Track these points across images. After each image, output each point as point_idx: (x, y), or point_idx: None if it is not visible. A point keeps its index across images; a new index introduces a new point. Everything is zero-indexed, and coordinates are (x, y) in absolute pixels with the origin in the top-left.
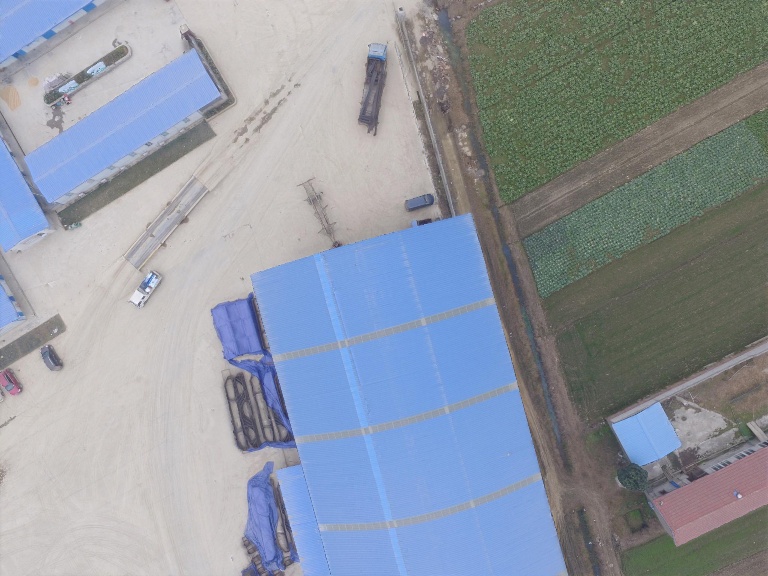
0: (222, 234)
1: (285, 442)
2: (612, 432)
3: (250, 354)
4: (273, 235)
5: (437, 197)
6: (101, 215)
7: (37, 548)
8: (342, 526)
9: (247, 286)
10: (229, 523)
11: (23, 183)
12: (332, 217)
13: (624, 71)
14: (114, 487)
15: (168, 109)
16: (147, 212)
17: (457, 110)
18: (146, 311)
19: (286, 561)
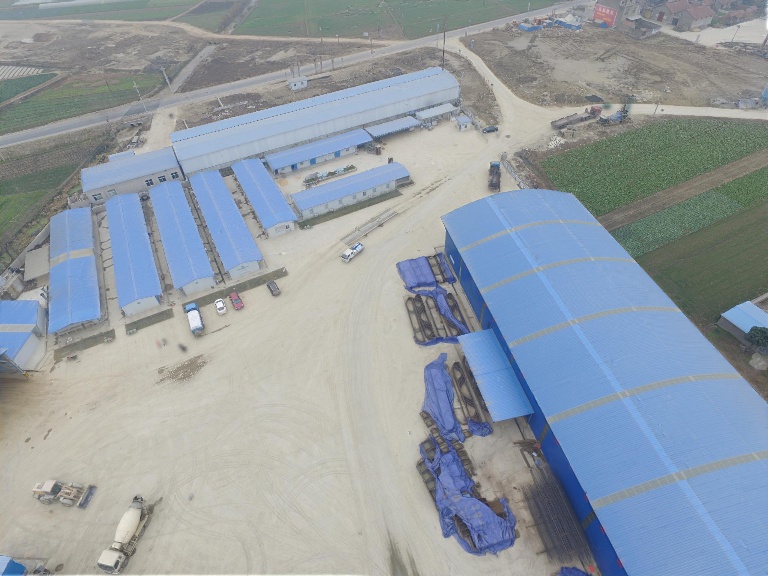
0: (405, 231)
1: None
2: (726, 331)
3: (425, 287)
4: (439, 232)
5: None
6: (326, 224)
7: (213, 425)
8: (530, 336)
9: (422, 254)
10: (407, 401)
11: (287, 203)
12: None
13: None
14: (302, 373)
15: (381, 178)
16: (356, 223)
17: (543, 188)
18: (349, 266)
19: (465, 433)
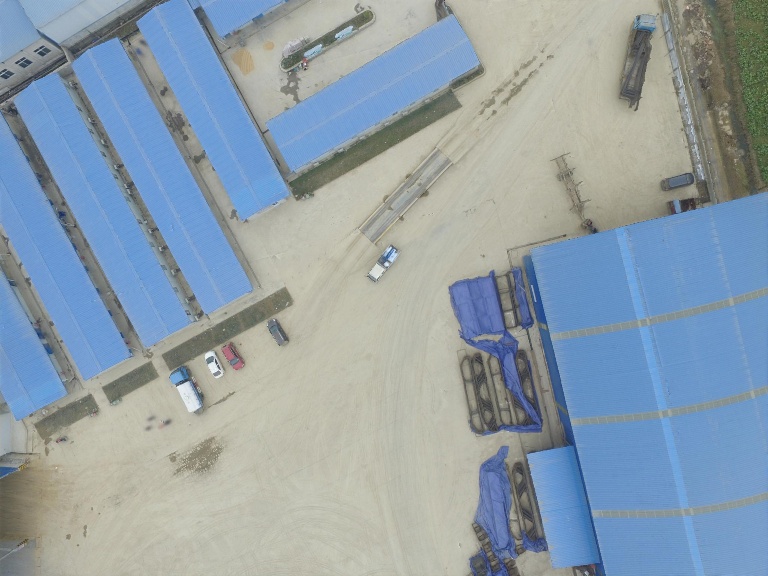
0: (463, 209)
1: (524, 426)
2: None
3: (488, 334)
4: (518, 211)
5: (703, 176)
6: (335, 186)
7: (252, 529)
8: (624, 513)
9: (488, 263)
10: (458, 508)
11: (264, 150)
12: (581, 194)
13: None
14: (337, 468)
15: (424, 76)
16: (384, 184)
17: (719, 87)
18: (379, 287)
19: (518, 549)
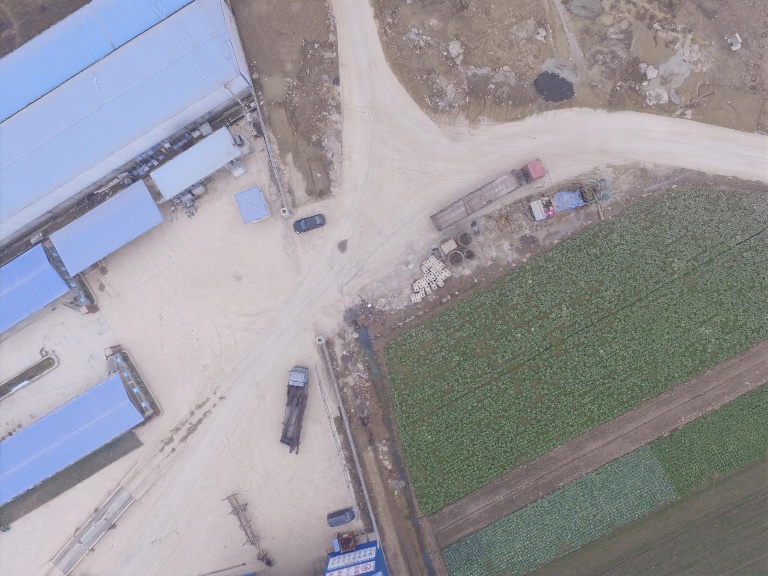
0: (149, 540)
1: None
2: None
3: None
4: (200, 542)
5: None
6: (29, 519)
7: None
8: None
9: None
10: None
11: None
12: (257, 526)
13: (535, 394)
14: None
15: (92, 434)
16: (75, 517)
17: (377, 425)
18: None
19: None
